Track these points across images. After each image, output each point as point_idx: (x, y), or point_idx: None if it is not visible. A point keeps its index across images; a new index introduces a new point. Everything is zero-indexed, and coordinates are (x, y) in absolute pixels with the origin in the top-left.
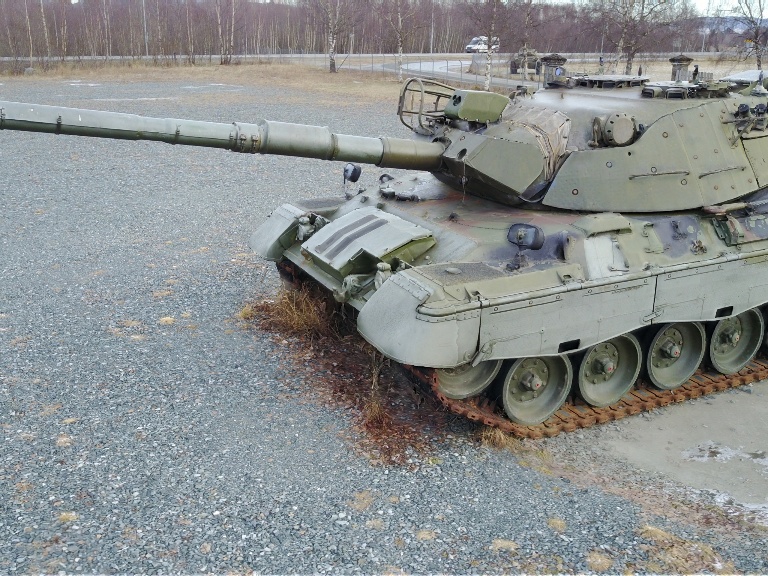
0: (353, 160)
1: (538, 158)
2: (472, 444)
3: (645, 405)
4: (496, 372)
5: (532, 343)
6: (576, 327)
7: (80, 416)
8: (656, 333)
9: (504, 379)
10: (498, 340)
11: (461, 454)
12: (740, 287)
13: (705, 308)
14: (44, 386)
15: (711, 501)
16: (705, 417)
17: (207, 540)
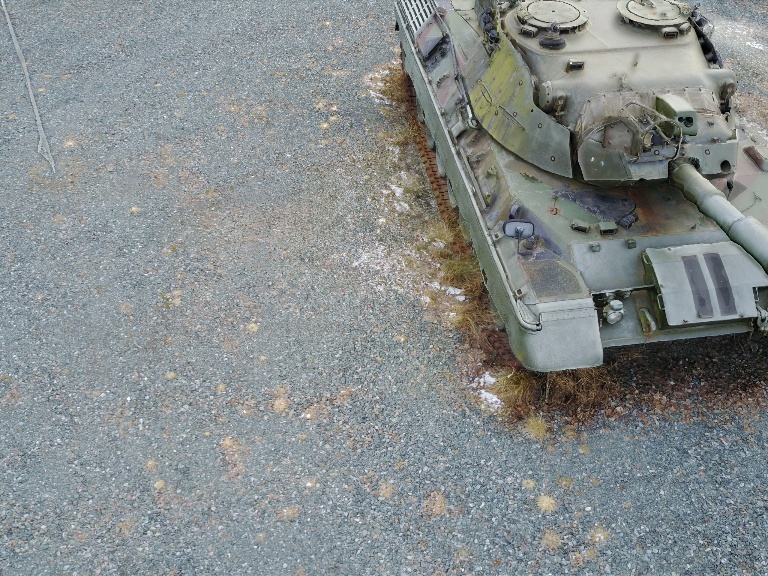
0: None
1: None
2: None
3: None
4: None
5: None
6: None
7: None
8: None
9: None
10: None
11: None
12: None
13: None
14: None
15: None
16: None
17: None
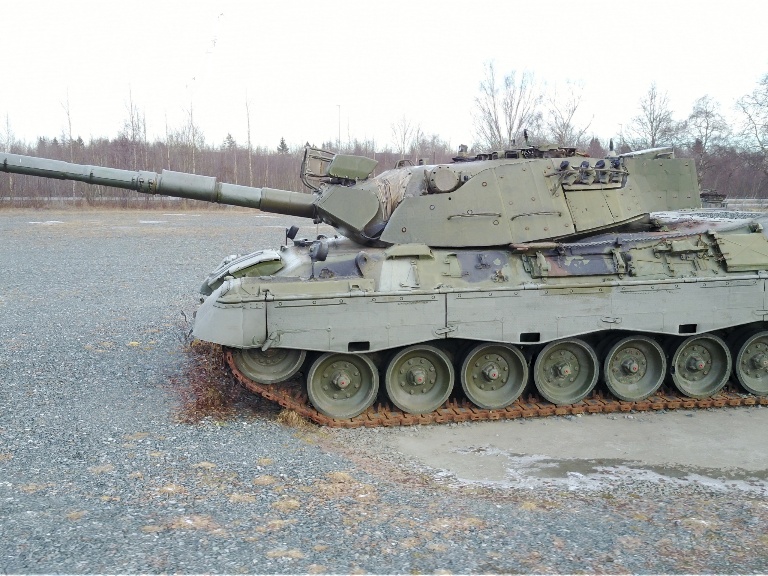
0: (237, 204)
1: (374, 202)
2: (269, 421)
3: (454, 416)
4: (299, 365)
5: (320, 338)
6: (364, 330)
7: (6, 382)
8: (469, 353)
9: (308, 372)
10: (285, 331)
11: (249, 423)
12: (545, 315)
13: (506, 330)
14: (1, 367)
15: (431, 473)
16: (506, 430)
17: (4, 440)
